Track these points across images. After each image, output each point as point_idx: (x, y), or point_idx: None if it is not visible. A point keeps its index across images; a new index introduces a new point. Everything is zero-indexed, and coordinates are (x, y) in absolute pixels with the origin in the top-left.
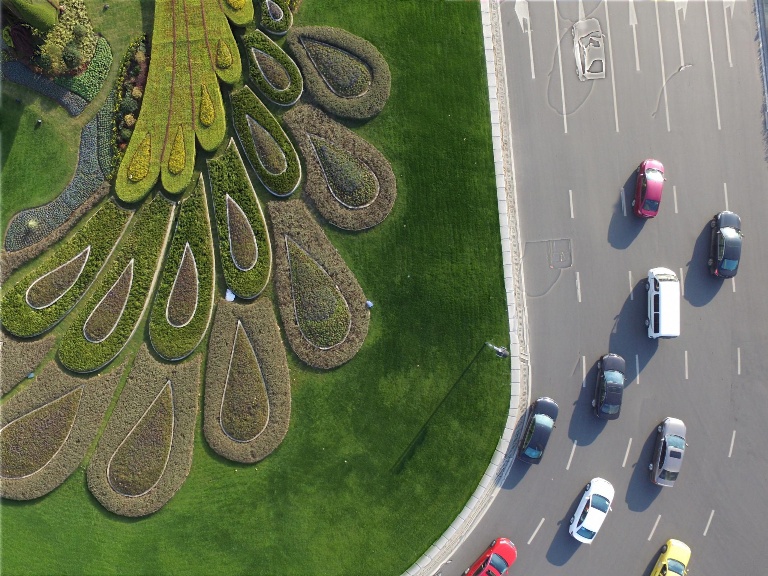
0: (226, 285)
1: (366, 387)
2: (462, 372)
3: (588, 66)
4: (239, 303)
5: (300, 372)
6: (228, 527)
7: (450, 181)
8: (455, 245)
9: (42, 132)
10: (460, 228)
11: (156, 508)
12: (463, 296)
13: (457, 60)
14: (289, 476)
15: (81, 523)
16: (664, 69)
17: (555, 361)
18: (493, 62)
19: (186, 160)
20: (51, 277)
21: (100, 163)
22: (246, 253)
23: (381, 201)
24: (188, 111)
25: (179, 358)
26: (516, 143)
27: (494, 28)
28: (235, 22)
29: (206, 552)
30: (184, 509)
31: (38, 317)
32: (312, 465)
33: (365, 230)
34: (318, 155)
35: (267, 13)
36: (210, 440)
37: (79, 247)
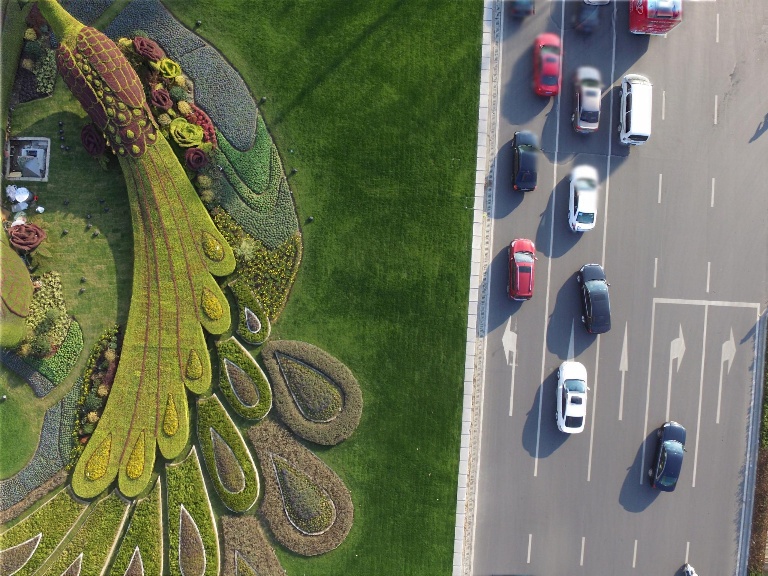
0: None
1: None
2: None
3: (568, 412)
4: None
5: None
6: None
7: (409, 515)
8: None
9: (6, 407)
10: (412, 563)
11: None
12: None
13: (434, 391)
14: None
15: None
16: (647, 423)
17: None
18: (471, 395)
19: (145, 466)
20: (1, 558)
21: (60, 450)
22: (194, 567)
23: (335, 531)
24: (152, 417)
25: None
26: (482, 480)
27: (478, 358)
28: (210, 332)
29: None
30: None
31: None
32: None
33: (316, 555)
34: (278, 476)
35: (244, 324)
36: None
37: (31, 533)
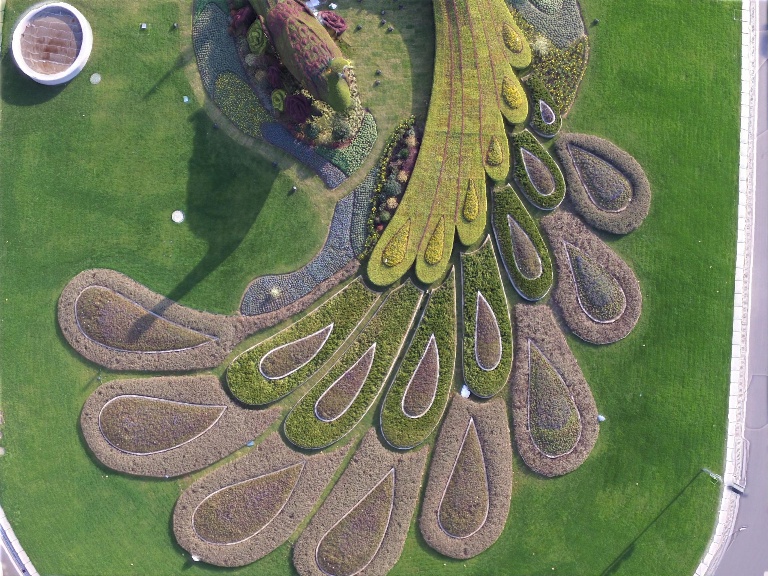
0: (463, 381)
1: (584, 499)
2: (677, 495)
3: None
4: (474, 401)
5: (522, 476)
6: None
7: (692, 306)
8: (688, 370)
9: (295, 199)
10: (695, 354)
11: None
12: (689, 421)
13: (712, 187)
14: None
15: None
16: None
17: (763, 493)
18: (745, 193)
19: (444, 252)
20: (290, 349)
21: (352, 240)
22: (491, 353)
23: (627, 319)
24: (452, 203)
25: (407, 448)
26: (755, 276)
27: (749, 159)
28: (509, 120)
29: None
30: None
31: (269, 387)
32: (520, 568)
33: (606, 345)
34: (572, 264)
35: (539, 115)
36: (426, 532)
37: (322, 323)
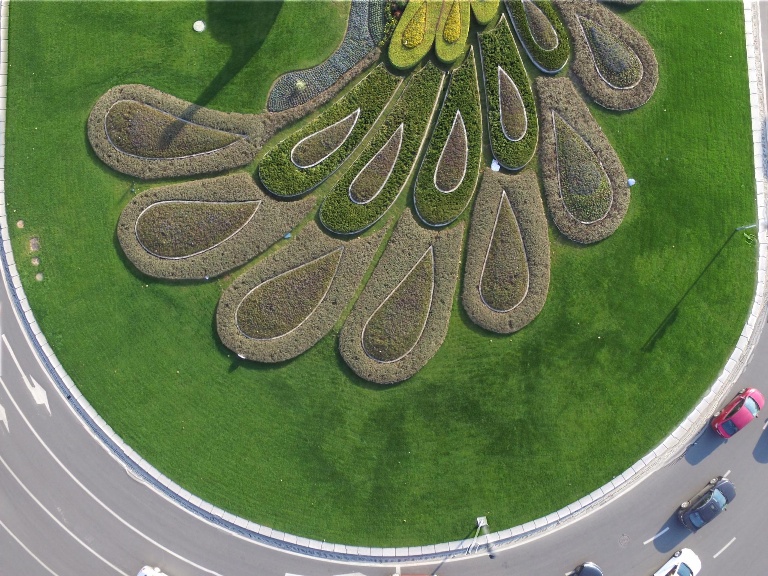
0: (492, 155)
1: (623, 264)
2: (714, 256)
3: None
4: (505, 173)
5: (559, 246)
6: (479, 398)
7: (707, 71)
8: (711, 132)
9: None
10: (716, 117)
11: (409, 375)
12: (717, 182)
13: None
14: (543, 349)
15: (328, 388)
16: None
17: None
18: None
19: (461, 30)
20: (319, 136)
21: (371, 30)
22: (517, 123)
23: (646, 84)
24: None
25: (443, 224)
26: (765, 42)
27: None
28: None
29: (455, 423)
30: (436, 378)
31: (302, 176)
32: (566, 339)
33: (628, 111)
34: (586, 36)
35: None
36: (469, 308)
37: (349, 109)
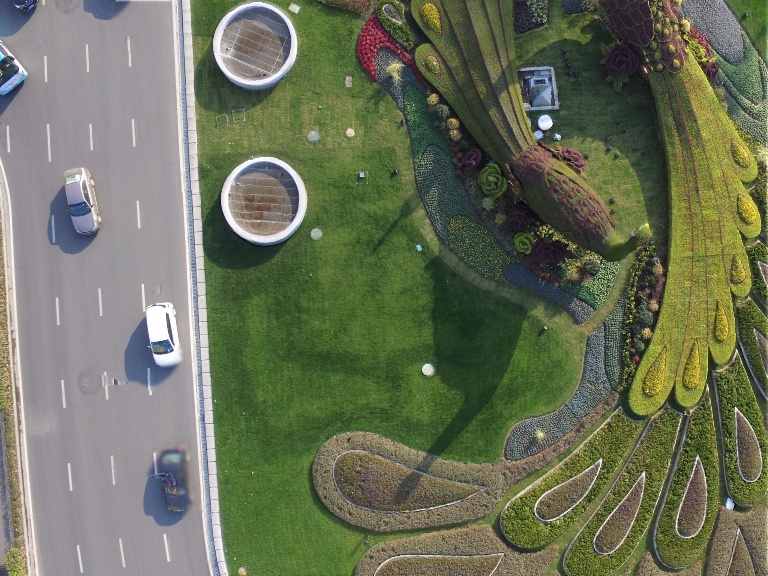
0: (726, 494)
1: None
2: None
3: None
4: (739, 511)
5: None
6: None
7: None
8: None
9: (546, 339)
10: None
11: None
12: None
13: None
14: None
15: None
16: None
17: None
18: None
19: (700, 375)
20: (564, 491)
21: (608, 373)
22: (754, 466)
23: None
24: (703, 326)
25: (683, 567)
26: None
27: None
28: (746, 236)
29: None
30: None
31: (546, 529)
32: None
33: None
34: None
35: None
36: None
37: (591, 460)
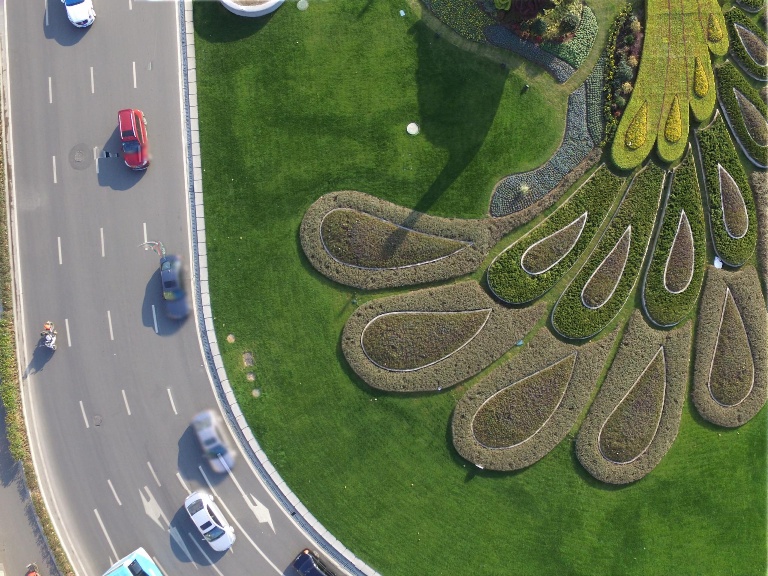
0: (714, 253)
1: None
2: None
3: None
4: (728, 270)
5: None
6: (710, 491)
7: None
8: None
9: (528, 97)
10: None
11: (644, 474)
12: None
13: None
14: (767, 439)
15: (566, 492)
16: None
17: None
18: None
19: (682, 129)
20: (550, 242)
21: (590, 130)
22: (740, 221)
23: None
24: (682, 82)
25: (673, 324)
26: None
27: None
28: None
29: (688, 517)
30: (669, 475)
31: (534, 283)
32: None
33: None
34: None
35: None
36: (700, 405)
37: (576, 213)
